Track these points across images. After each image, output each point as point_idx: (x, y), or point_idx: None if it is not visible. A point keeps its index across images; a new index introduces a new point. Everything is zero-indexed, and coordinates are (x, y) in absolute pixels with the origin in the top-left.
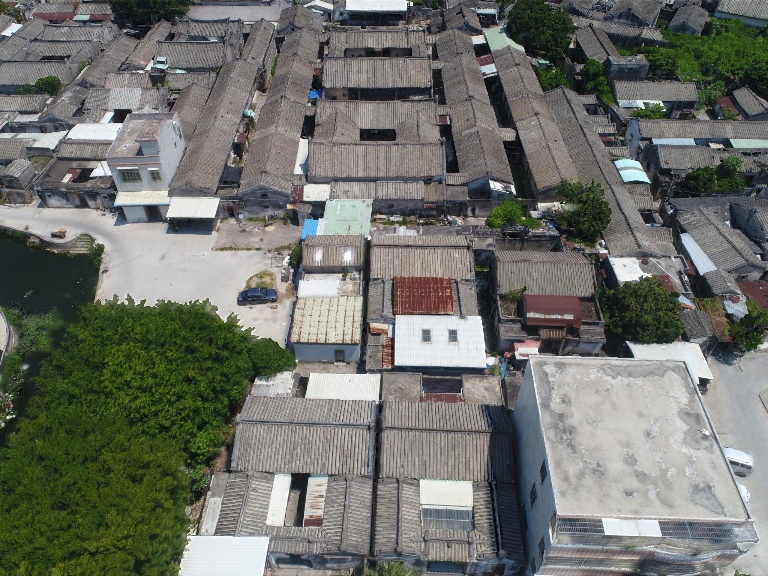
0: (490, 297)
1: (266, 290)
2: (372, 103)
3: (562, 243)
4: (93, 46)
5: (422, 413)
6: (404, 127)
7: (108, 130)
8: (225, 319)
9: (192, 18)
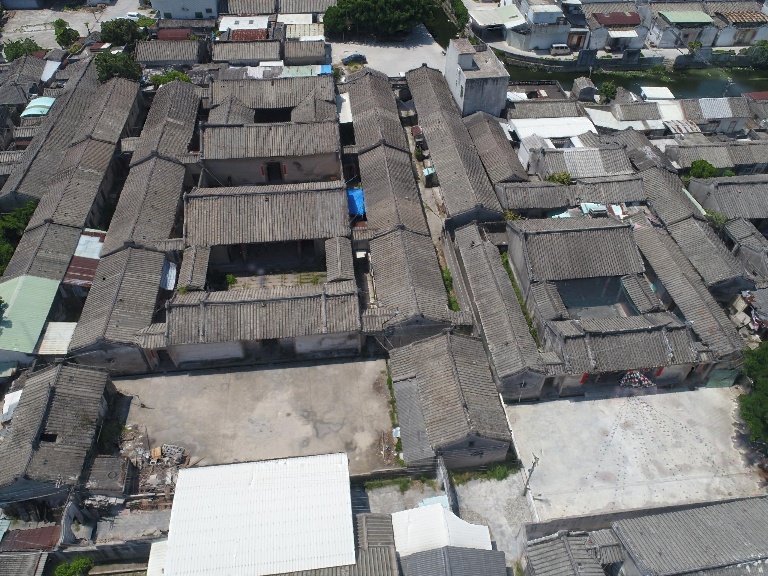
0: (208, 51)
1: (349, 59)
2: (276, 124)
3: (144, 68)
4: (759, 256)
5: (258, 6)
6: (244, 118)
7: (555, 125)
8: (371, 55)
9: (660, 325)
